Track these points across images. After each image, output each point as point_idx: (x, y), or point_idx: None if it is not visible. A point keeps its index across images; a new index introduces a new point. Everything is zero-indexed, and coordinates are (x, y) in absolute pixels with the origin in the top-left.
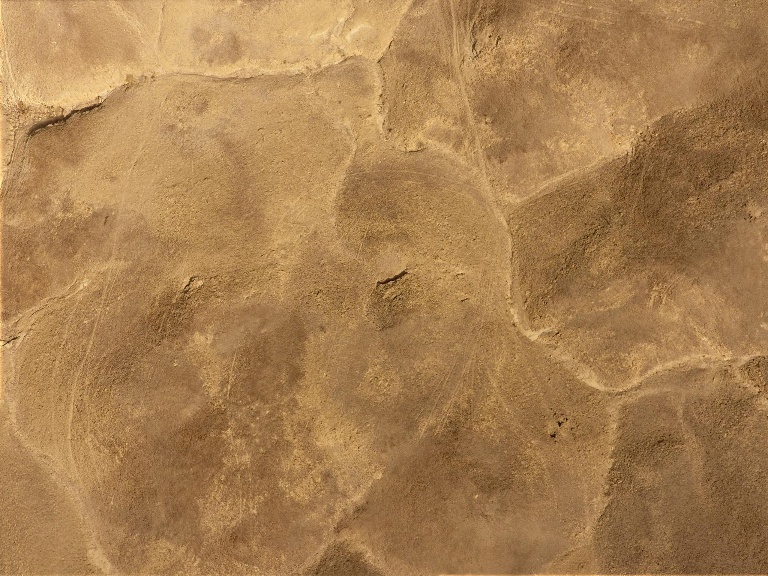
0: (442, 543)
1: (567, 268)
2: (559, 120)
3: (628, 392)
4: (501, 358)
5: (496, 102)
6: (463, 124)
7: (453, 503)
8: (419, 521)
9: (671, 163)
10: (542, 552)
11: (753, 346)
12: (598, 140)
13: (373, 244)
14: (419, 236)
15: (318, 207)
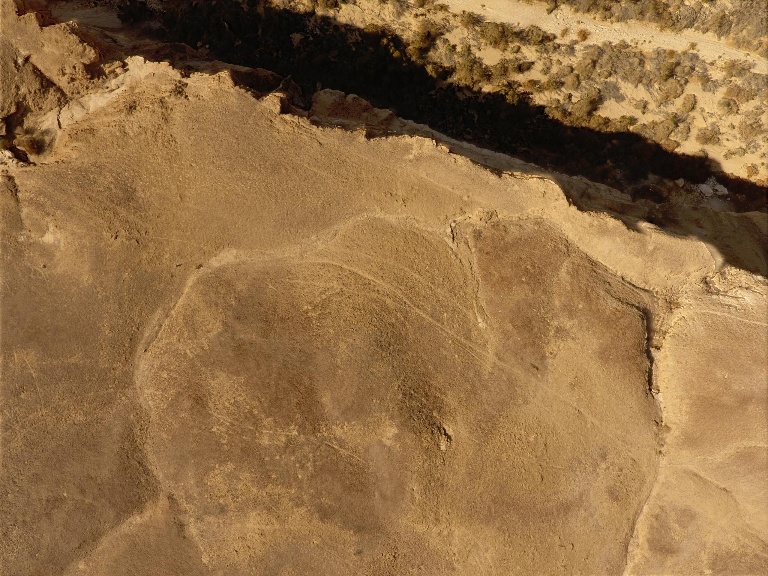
0: None
1: None
2: None
3: None
4: None
5: None
6: None
7: None
8: None
9: None
10: None
11: None
12: None
13: None
14: None
15: None
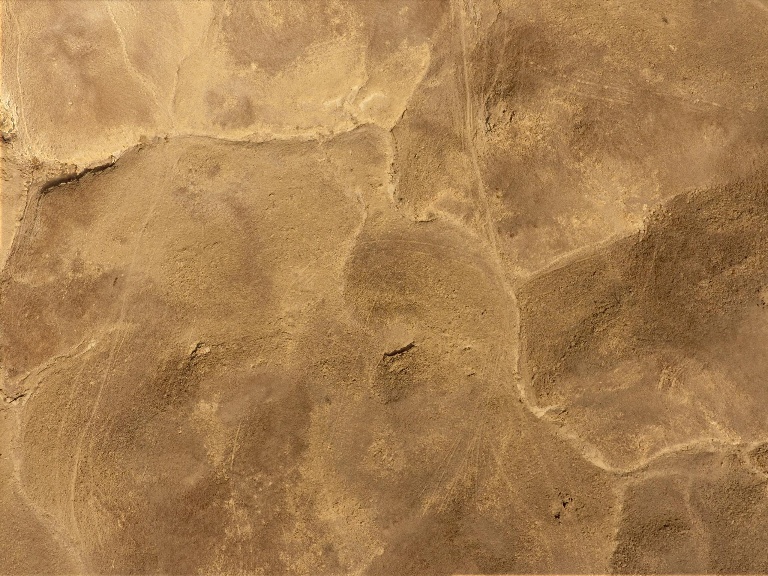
0: None
1: (576, 346)
2: (571, 196)
3: (634, 473)
4: (507, 435)
5: (508, 176)
6: (474, 197)
7: None
8: None
9: (684, 244)
10: None
11: (763, 432)
12: (610, 217)
13: (381, 315)
14: (427, 309)
15: (327, 275)
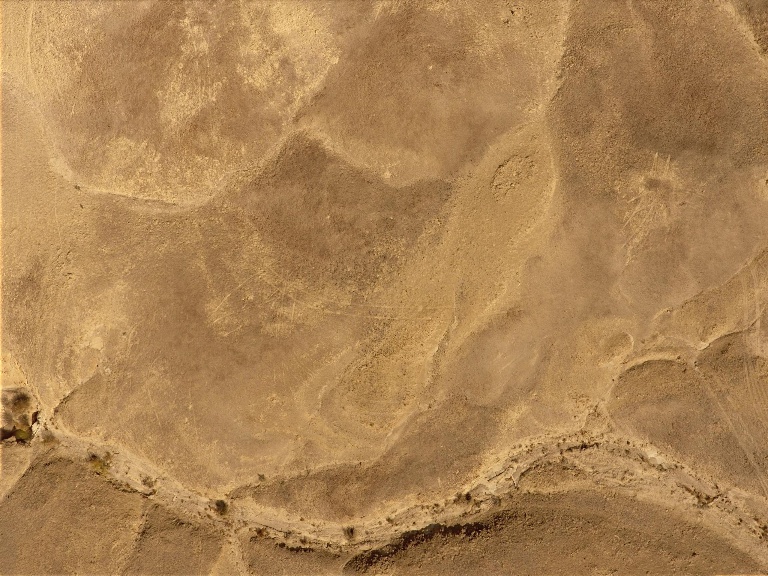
0: (398, 117)
1: None
2: None
3: None
4: None
5: None
6: None
7: (408, 75)
8: (376, 99)
9: None
10: (496, 124)
11: None
12: None
13: None
14: None
15: None
